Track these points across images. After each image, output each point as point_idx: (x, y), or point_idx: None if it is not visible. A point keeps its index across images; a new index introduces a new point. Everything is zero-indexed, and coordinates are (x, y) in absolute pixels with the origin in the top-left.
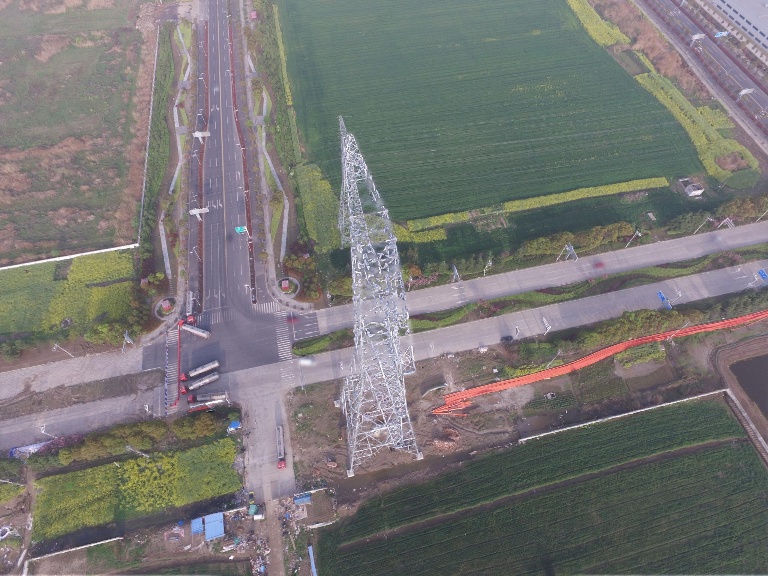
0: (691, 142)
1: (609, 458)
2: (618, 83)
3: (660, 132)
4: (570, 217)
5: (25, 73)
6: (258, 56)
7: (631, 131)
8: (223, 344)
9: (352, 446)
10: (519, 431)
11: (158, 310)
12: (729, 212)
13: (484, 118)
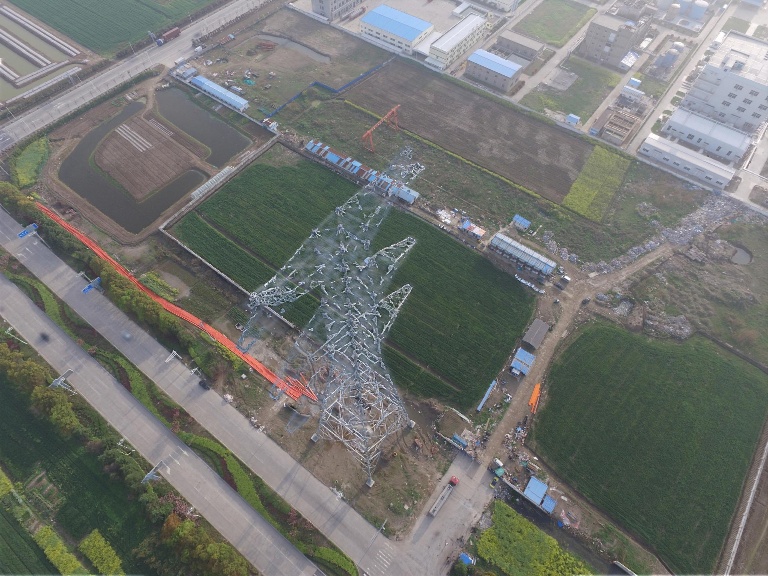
0: None
1: (265, 271)
2: None
3: None
4: None
5: None
6: None
7: None
8: None
9: None
10: (285, 332)
11: None
12: None
13: None
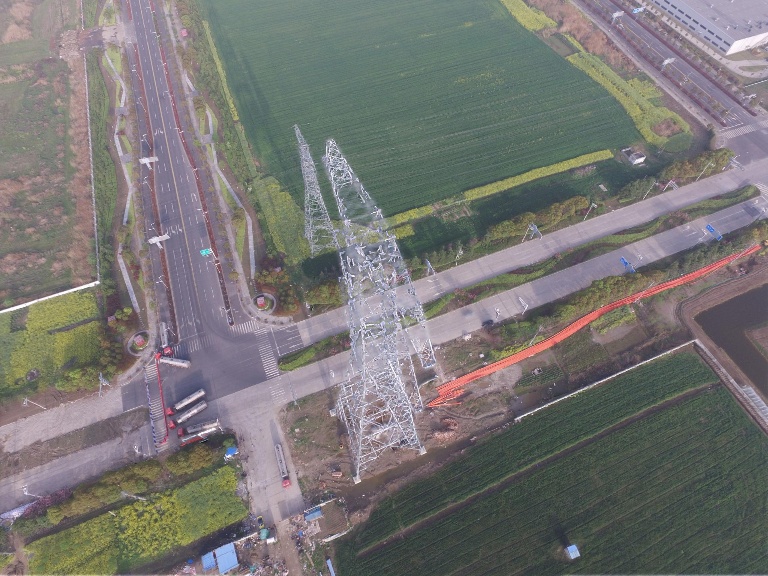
0: (627, 114)
1: (601, 422)
2: (552, 65)
3: (598, 107)
4: (528, 198)
5: None
6: (196, 74)
7: (571, 109)
8: (206, 371)
9: None
10: (513, 410)
11: (131, 347)
12: (671, 175)
13: (432, 112)
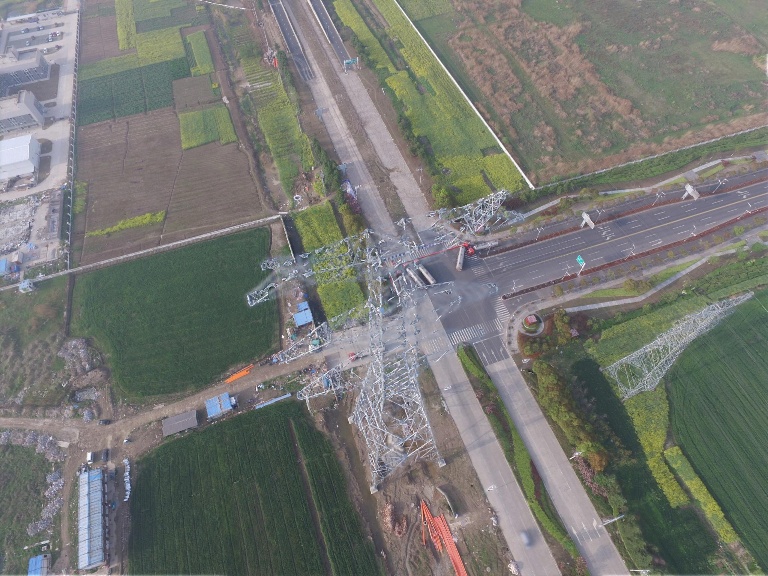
0: None
1: None
2: None
3: None
4: None
5: (690, 44)
6: None
7: None
8: None
9: None
10: None
11: None
12: None
13: None
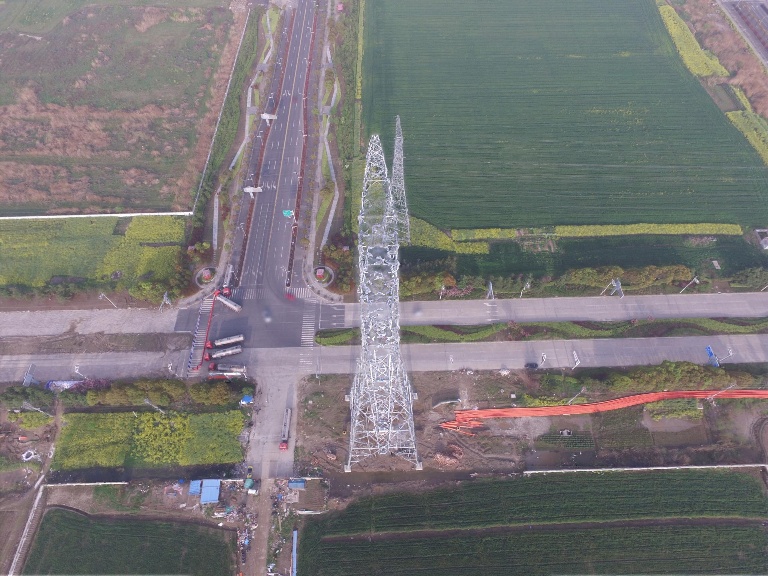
0: None
1: (617, 510)
2: (706, 117)
3: (744, 176)
4: (624, 251)
5: (124, 40)
6: (336, 48)
7: (711, 170)
8: (251, 320)
9: (352, 442)
10: (526, 462)
11: (199, 277)
12: None
13: (552, 136)
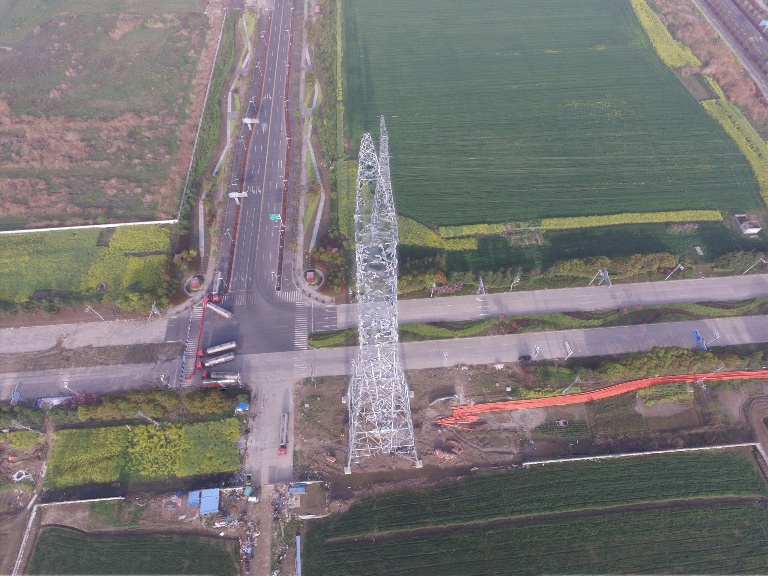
0: (754, 176)
1: (616, 496)
2: (682, 107)
3: (721, 163)
4: (610, 241)
5: (98, 48)
6: (315, 49)
7: (689, 159)
8: (243, 326)
9: (351, 444)
10: (525, 454)
11: (187, 286)
12: None
13: (533, 131)
